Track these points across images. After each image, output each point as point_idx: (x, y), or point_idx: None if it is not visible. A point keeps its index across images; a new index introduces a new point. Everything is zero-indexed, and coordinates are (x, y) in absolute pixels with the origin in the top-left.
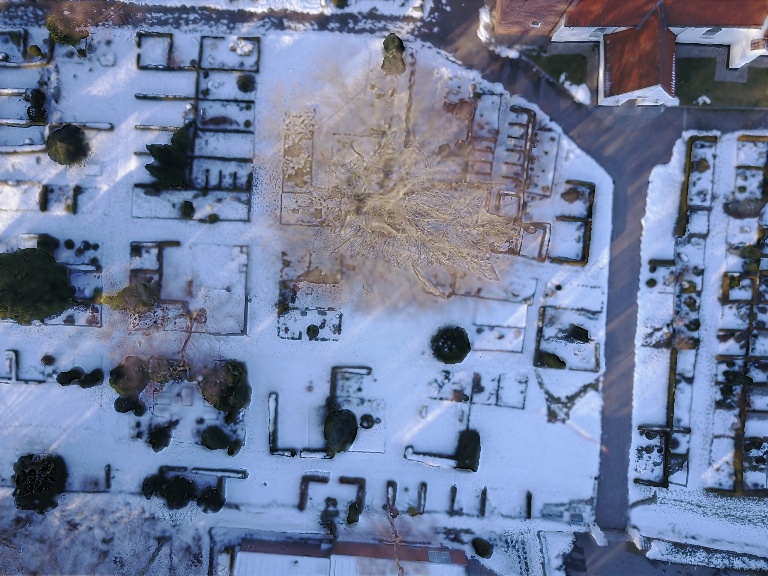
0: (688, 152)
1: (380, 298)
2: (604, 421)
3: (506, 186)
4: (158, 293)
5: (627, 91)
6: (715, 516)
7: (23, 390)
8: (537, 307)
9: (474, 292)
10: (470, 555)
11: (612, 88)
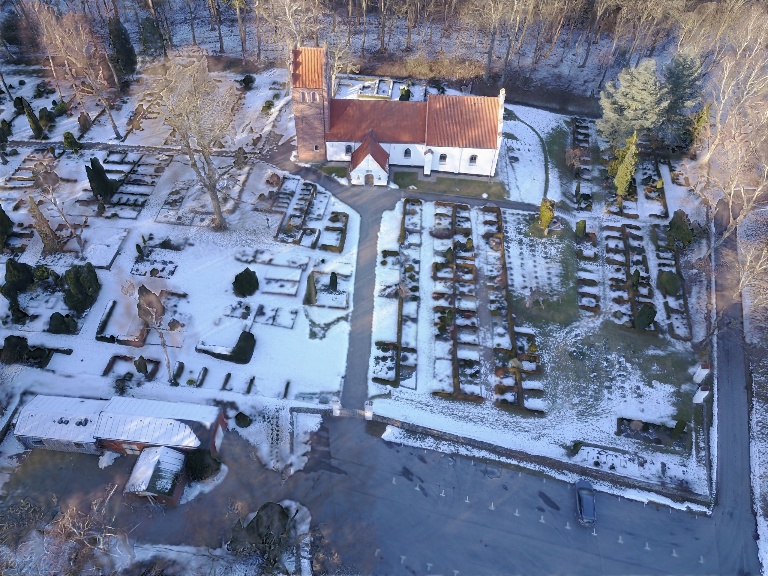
0: (404, 205)
1: (205, 261)
2: (351, 339)
3: (296, 213)
4: (62, 246)
5: (358, 164)
6: (441, 414)
7: None
8: (309, 272)
9: (268, 261)
10: (231, 427)
11: None
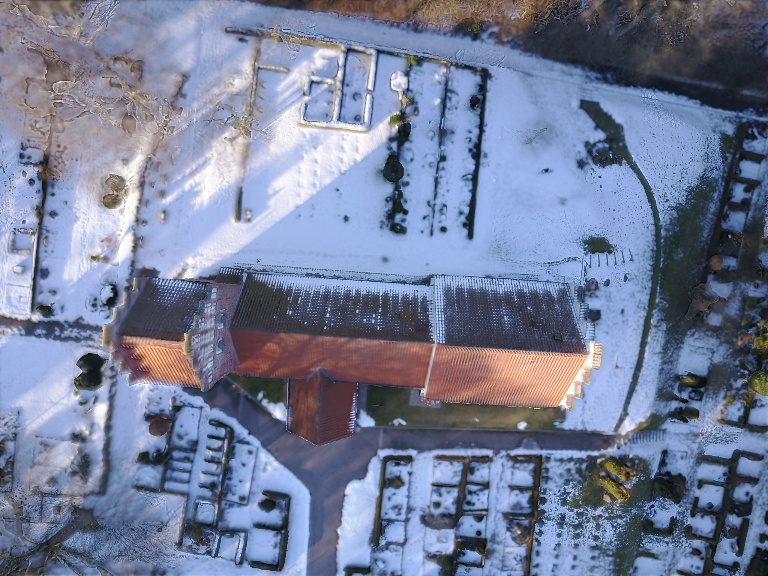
0: (381, 471)
1: None
2: None
3: (204, 494)
4: None
5: (299, 435)
6: None
7: None
8: None
9: None
10: None
11: (292, 424)
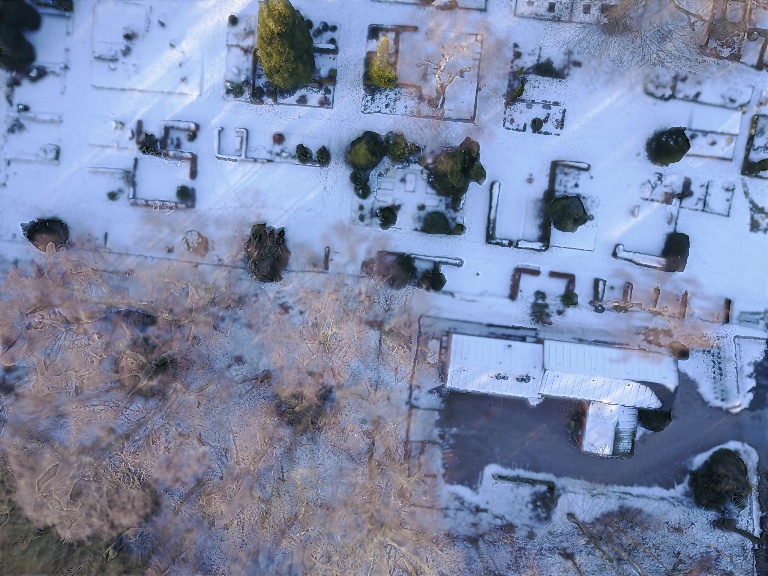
0: None
1: (602, 97)
2: None
3: None
4: None
5: None
6: None
7: (248, 170)
8: (750, 116)
9: (693, 96)
10: None
11: None
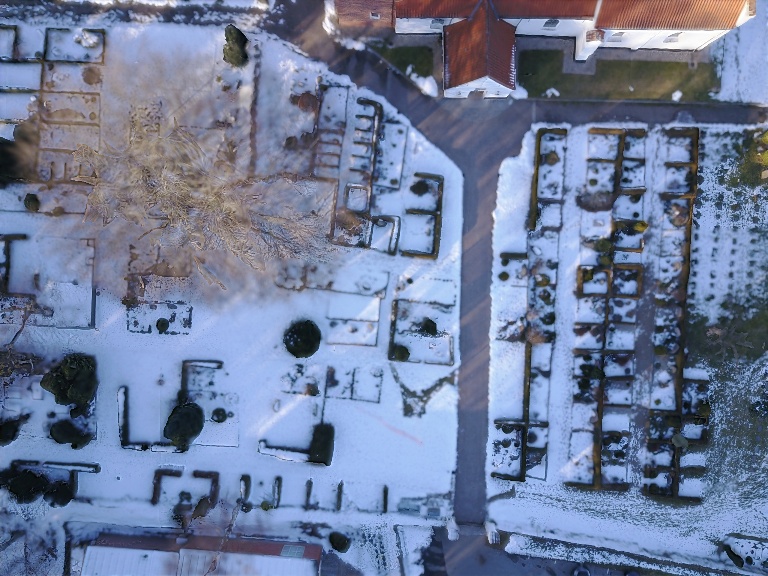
0: (537, 145)
1: (231, 291)
2: (460, 415)
3: (354, 179)
4: (5, 286)
5: (462, 83)
6: (575, 510)
7: None
8: (390, 300)
9: (325, 285)
10: (328, 549)
11: (451, 80)
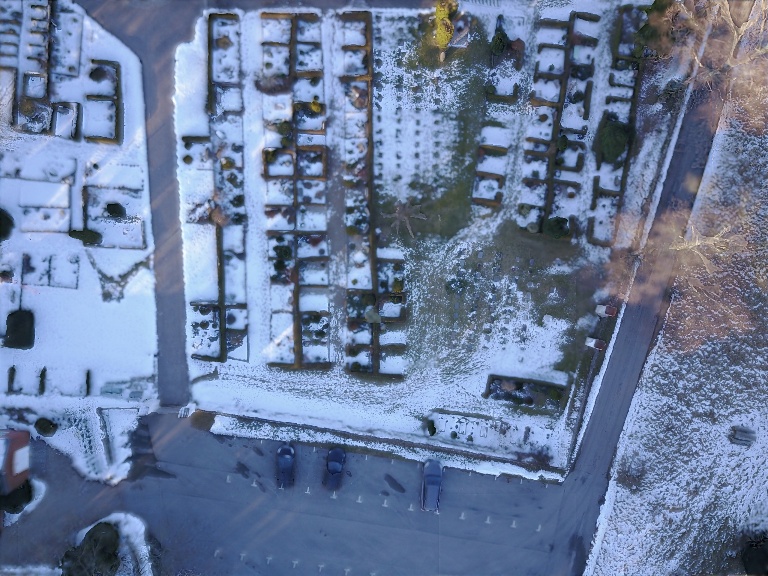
0: (208, 29)
1: None
2: (158, 298)
3: (34, 68)
4: None
5: None
6: (280, 390)
7: None
8: (81, 187)
9: (14, 174)
10: (35, 436)
11: None
